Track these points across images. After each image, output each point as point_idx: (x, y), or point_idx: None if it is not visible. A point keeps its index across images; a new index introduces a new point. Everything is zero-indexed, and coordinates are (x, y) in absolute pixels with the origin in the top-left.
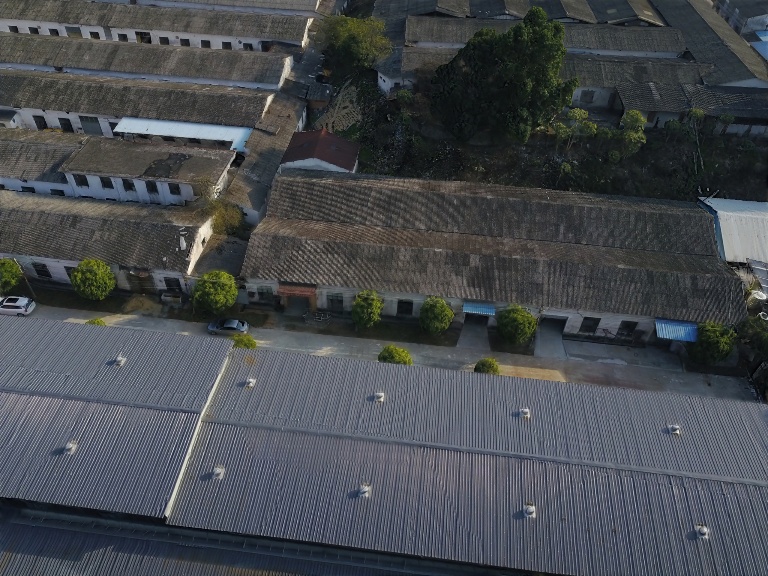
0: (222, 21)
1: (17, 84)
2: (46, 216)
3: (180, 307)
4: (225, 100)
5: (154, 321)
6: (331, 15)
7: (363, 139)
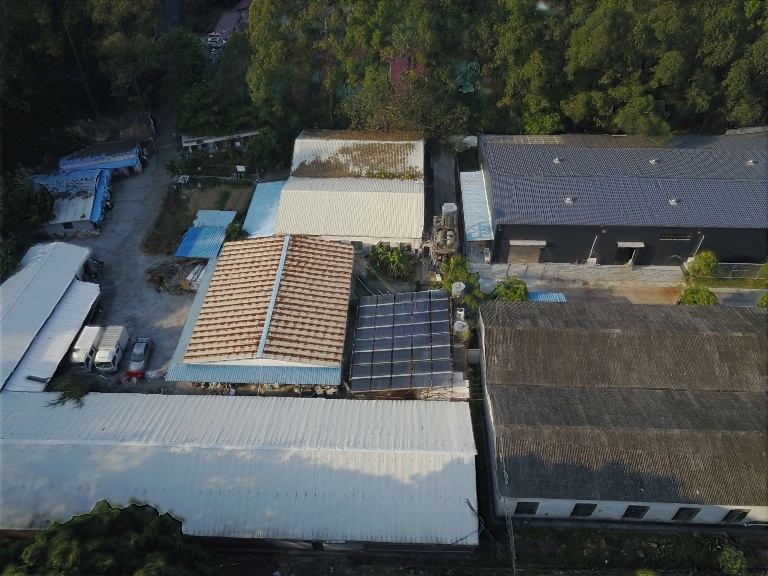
0: None
1: None
2: None
3: None
4: None
5: None
6: None
7: None
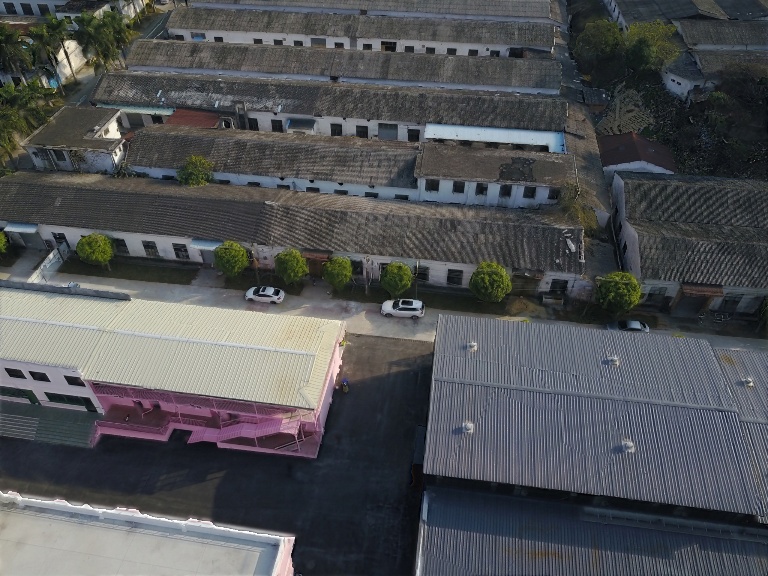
0: (468, 29)
1: (313, 93)
2: (423, 220)
3: (563, 309)
4: (525, 105)
5: (546, 323)
6: (563, 21)
7: (665, 142)
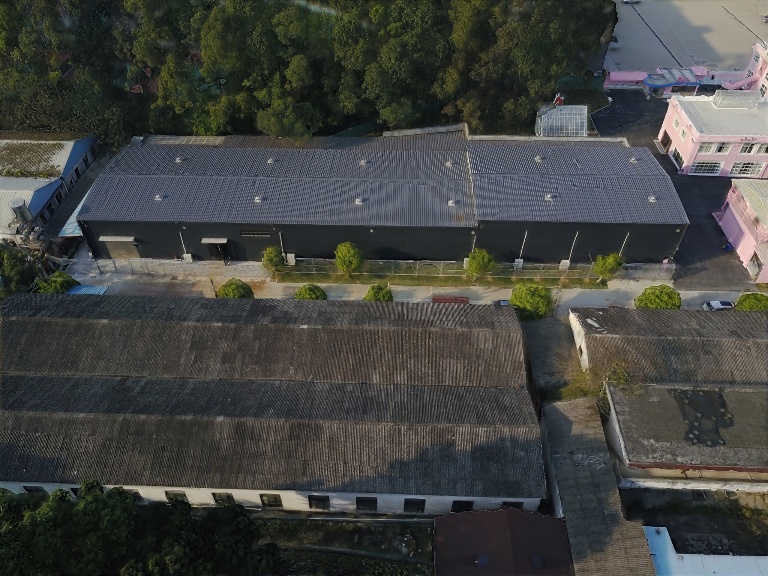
0: None
1: None
2: None
3: None
4: None
5: None
6: None
7: None
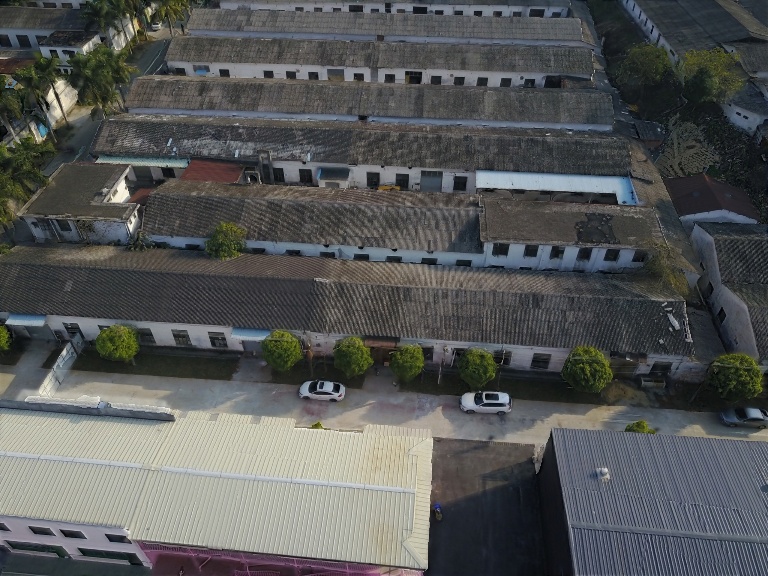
0: (499, 56)
1: (345, 138)
2: (500, 296)
3: (665, 393)
4: (583, 147)
5: (651, 413)
6: (596, 44)
7: (736, 183)
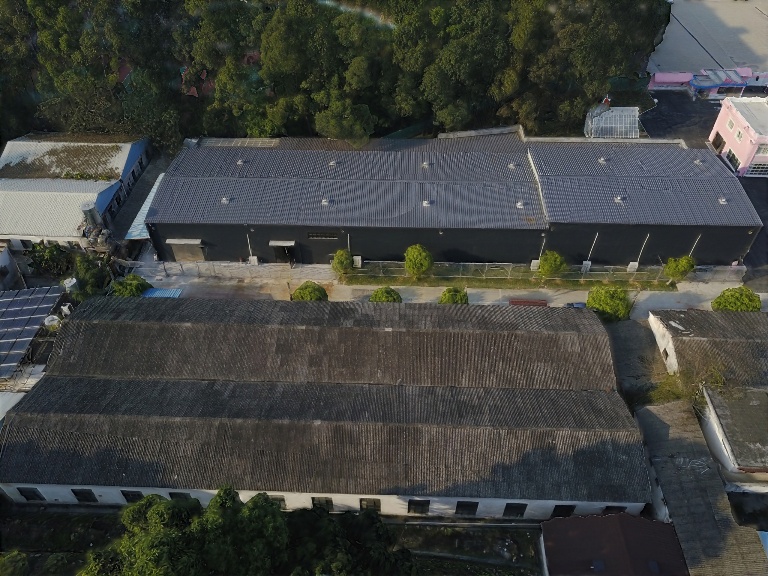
0: None
1: None
2: None
3: None
4: None
5: None
6: None
7: None
